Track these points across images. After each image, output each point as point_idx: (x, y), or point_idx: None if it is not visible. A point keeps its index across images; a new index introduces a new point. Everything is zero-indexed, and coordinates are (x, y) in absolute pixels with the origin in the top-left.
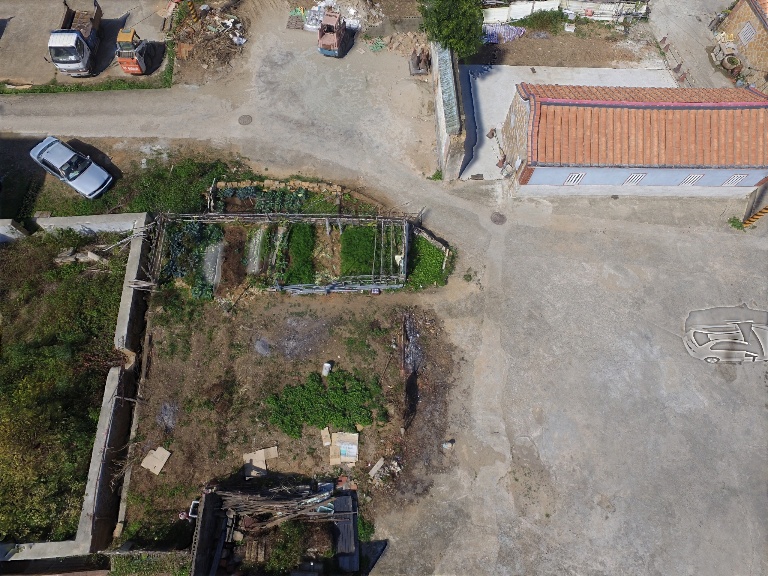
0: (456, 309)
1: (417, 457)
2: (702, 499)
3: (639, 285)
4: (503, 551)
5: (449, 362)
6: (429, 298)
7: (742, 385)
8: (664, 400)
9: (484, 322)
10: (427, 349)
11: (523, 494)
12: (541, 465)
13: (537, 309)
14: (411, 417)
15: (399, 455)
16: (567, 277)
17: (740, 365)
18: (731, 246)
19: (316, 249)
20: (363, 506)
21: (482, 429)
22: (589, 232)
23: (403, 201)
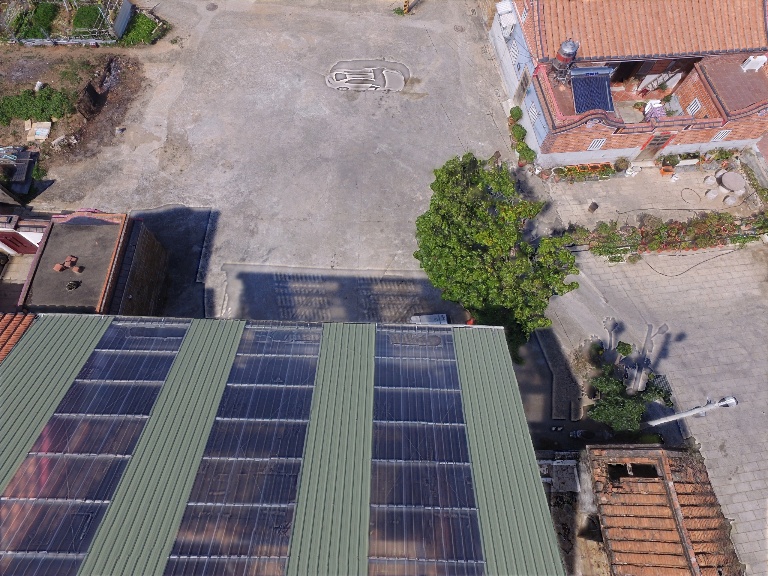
0: (156, 58)
1: (93, 137)
2: (300, 163)
3: (305, 46)
4: (140, 187)
5: (138, 86)
6: (137, 51)
7: (360, 103)
8: (296, 110)
9: (175, 66)
10: (123, 79)
11: (167, 159)
12: (187, 144)
13: (220, 59)
14: (96, 114)
15: (78, 133)
16: (251, 41)
17: (363, 92)
18: (388, 24)
19: (56, 20)
20: (42, 161)
21: (149, 123)
22: (278, 14)
23: (145, 0)
